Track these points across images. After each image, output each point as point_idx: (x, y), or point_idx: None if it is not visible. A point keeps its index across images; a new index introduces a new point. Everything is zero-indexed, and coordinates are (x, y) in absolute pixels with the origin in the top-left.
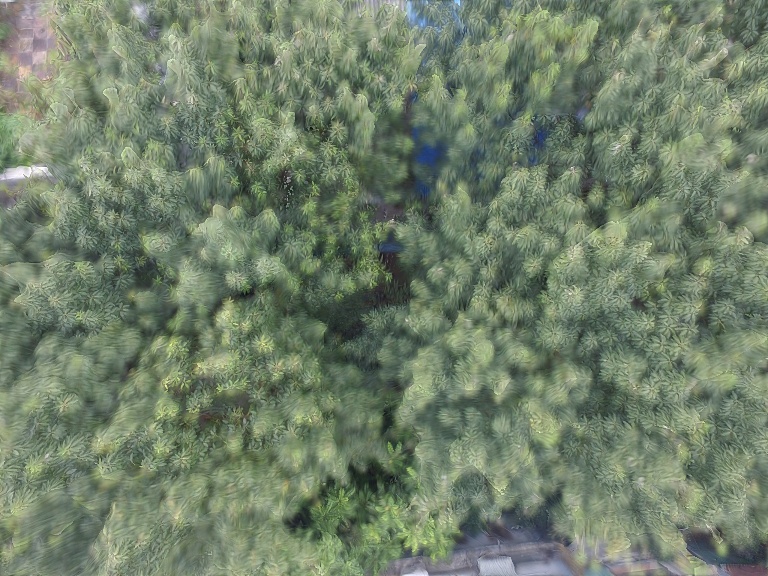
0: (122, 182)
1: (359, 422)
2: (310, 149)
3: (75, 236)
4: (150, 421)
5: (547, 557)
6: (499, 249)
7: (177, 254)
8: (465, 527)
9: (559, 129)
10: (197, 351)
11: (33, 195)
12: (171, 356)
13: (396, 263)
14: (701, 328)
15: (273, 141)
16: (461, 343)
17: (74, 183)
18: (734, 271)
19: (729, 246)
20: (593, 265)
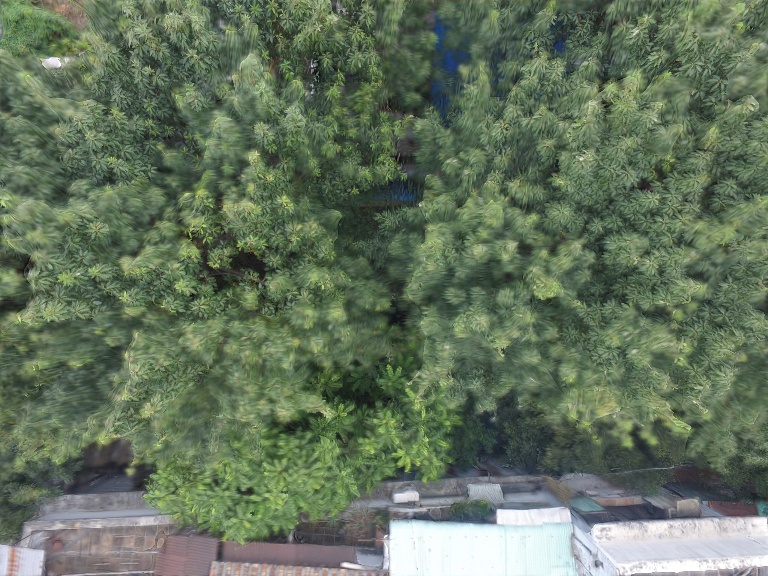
0: (162, 31)
1: (367, 308)
2: (339, 32)
3: (111, 94)
4: (174, 261)
5: (535, 489)
6: (514, 137)
7: (207, 118)
8: (456, 463)
9: (579, 29)
10: (220, 211)
11: (68, 71)
12: (196, 210)
13: (412, 163)
14: (702, 208)
15: (306, 11)
16: (472, 215)
17: (114, 39)
18: (738, 143)
19: (735, 116)
20: (604, 136)
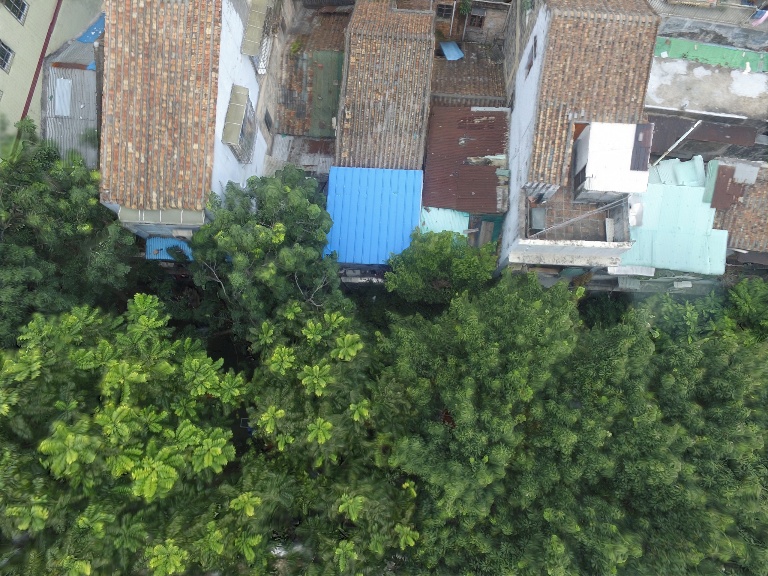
0: None
1: None
2: None
3: None
4: None
5: None
6: None
7: None
8: (615, 300)
9: None
10: None
11: None
12: None
13: None
14: None
15: None
16: None
17: None
18: None
19: None
20: None
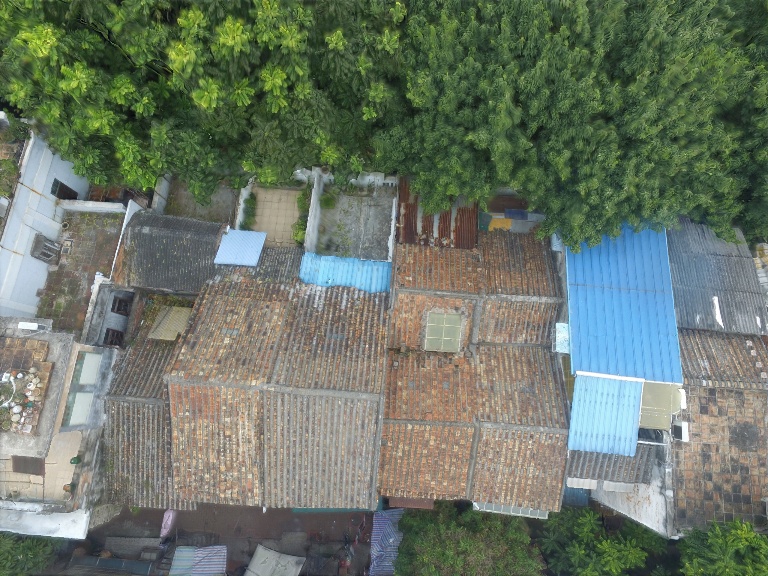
0: None
1: None
2: None
3: None
4: None
5: None
6: None
7: None
8: None
9: None
10: None
11: None
12: None
13: None
14: None
15: None
16: None
17: None
18: None
19: None
20: None
